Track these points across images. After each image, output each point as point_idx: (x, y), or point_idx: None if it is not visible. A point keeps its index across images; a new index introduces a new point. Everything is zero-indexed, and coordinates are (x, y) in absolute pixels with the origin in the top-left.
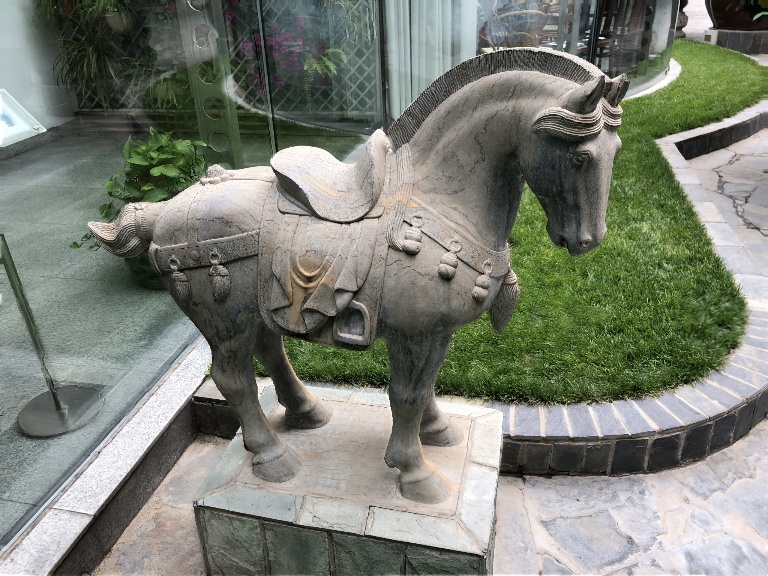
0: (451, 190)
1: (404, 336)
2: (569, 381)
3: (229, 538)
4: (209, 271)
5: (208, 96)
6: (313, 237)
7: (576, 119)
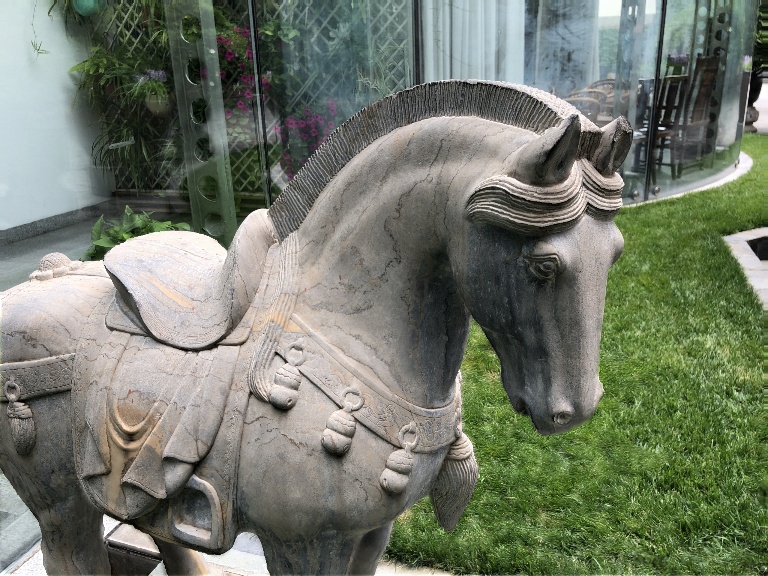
0: (351, 307)
1: (276, 538)
2: (597, 561)
3: None
4: (7, 409)
5: (203, 175)
6: (141, 370)
7: (529, 195)
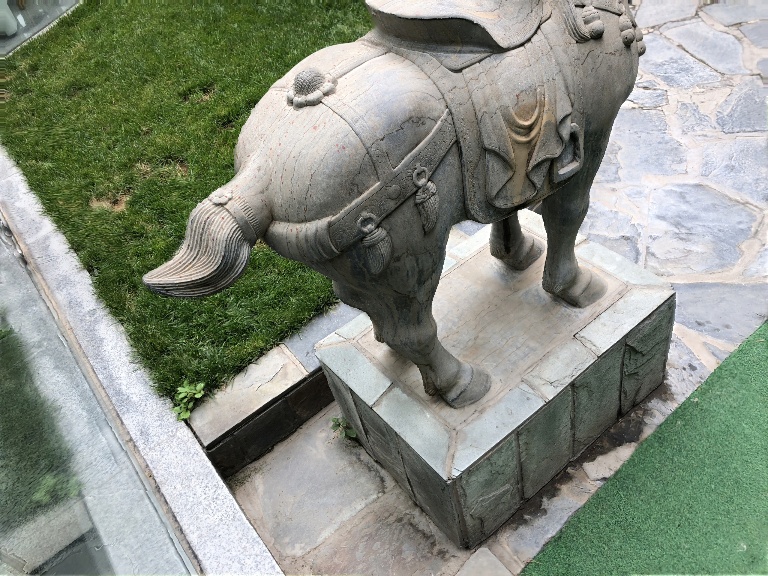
0: None
1: (599, 136)
2: None
3: (487, 479)
4: (415, 200)
5: None
6: (513, 76)
7: None
